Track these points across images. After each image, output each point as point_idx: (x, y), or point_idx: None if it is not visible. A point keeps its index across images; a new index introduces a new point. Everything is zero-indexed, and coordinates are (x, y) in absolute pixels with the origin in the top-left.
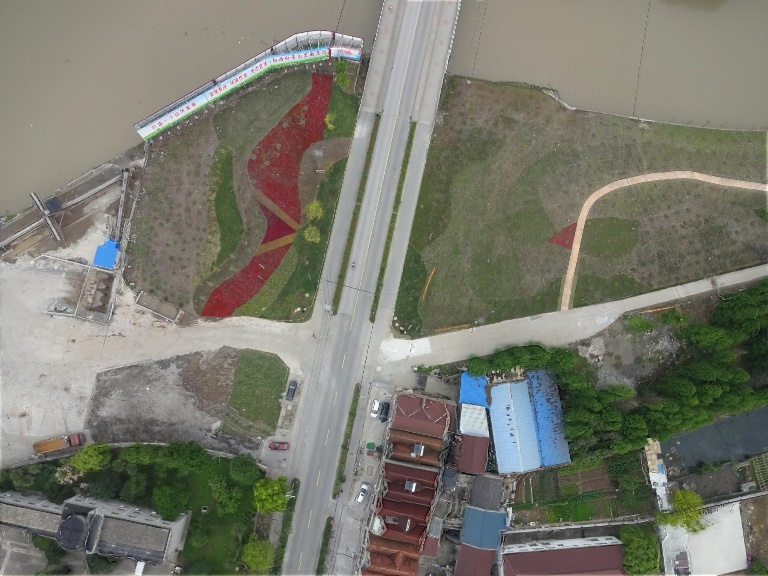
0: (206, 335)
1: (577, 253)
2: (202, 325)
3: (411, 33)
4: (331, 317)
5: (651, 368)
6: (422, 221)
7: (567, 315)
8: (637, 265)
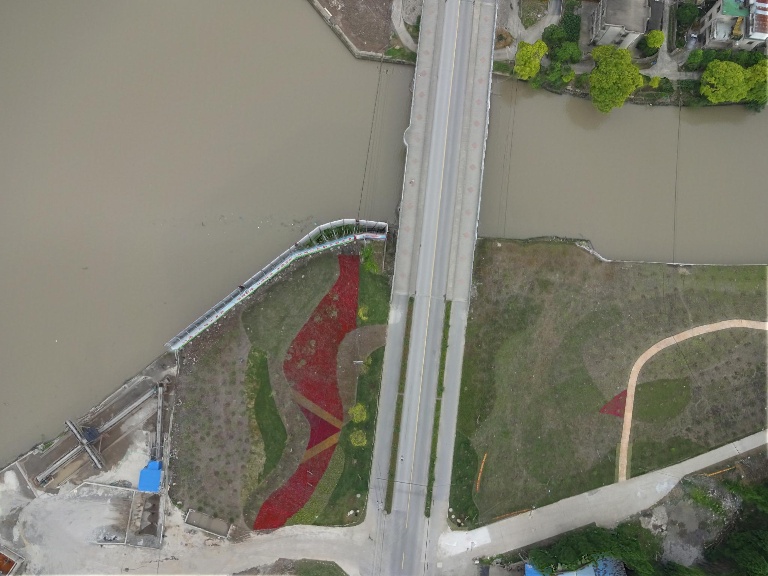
0: (260, 549)
1: (630, 421)
2: (255, 539)
3: (436, 206)
4: (385, 516)
5: (716, 532)
6: (468, 404)
7: (625, 486)
8: (692, 424)
